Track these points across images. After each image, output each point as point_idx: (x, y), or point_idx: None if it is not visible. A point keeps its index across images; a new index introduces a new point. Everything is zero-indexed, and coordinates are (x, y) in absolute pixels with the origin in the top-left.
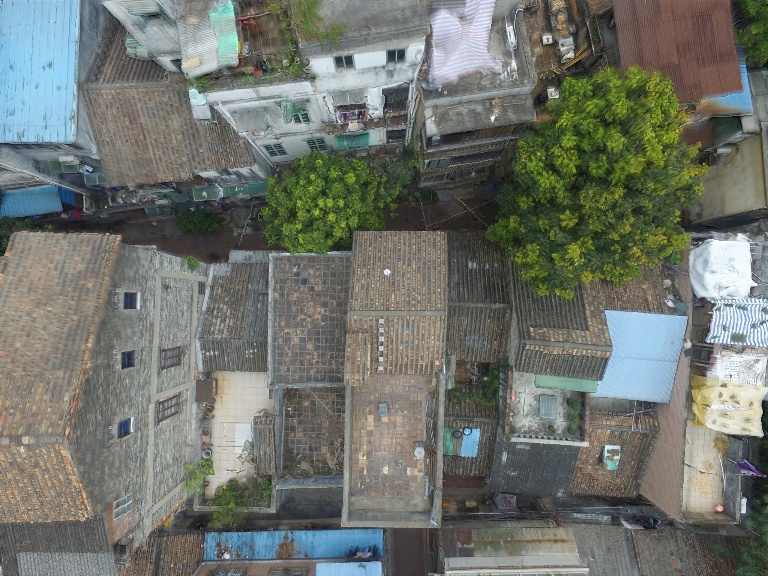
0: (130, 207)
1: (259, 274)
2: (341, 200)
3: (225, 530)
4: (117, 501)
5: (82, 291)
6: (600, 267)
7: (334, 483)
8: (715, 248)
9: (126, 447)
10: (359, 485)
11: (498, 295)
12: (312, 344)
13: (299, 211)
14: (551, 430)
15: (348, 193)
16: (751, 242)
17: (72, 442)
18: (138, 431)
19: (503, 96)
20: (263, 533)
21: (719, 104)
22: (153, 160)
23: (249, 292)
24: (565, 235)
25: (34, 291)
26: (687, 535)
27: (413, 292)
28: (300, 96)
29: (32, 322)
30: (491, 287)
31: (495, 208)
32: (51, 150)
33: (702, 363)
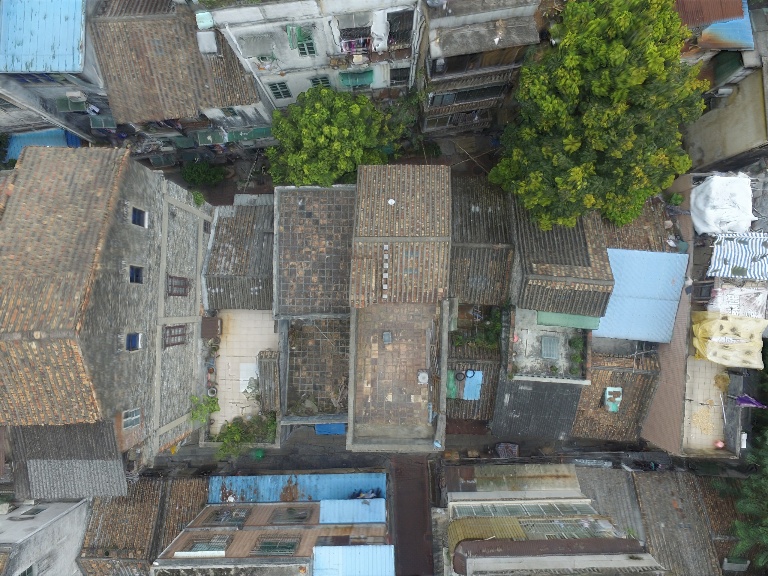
0: (135, 156)
1: (264, 215)
2: (346, 129)
3: (230, 474)
4: (126, 411)
5: (92, 199)
6: (602, 196)
7: (338, 419)
8: (716, 184)
9: (134, 361)
10: (363, 412)
11: (501, 236)
12: (317, 276)
13: (304, 139)
14: (553, 369)
15: (353, 125)
16: (752, 178)
17: (83, 338)
18: (146, 348)
19: (507, 18)
20: (267, 477)
21: (720, 38)
22: (159, 96)
23: (254, 232)
24: (568, 160)
25: (44, 200)
26: (688, 476)
27: (417, 220)
28: (306, 19)
29: (43, 228)
30: (494, 229)
31: (497, 157)
32: (58, 85)
33: (703, 300)
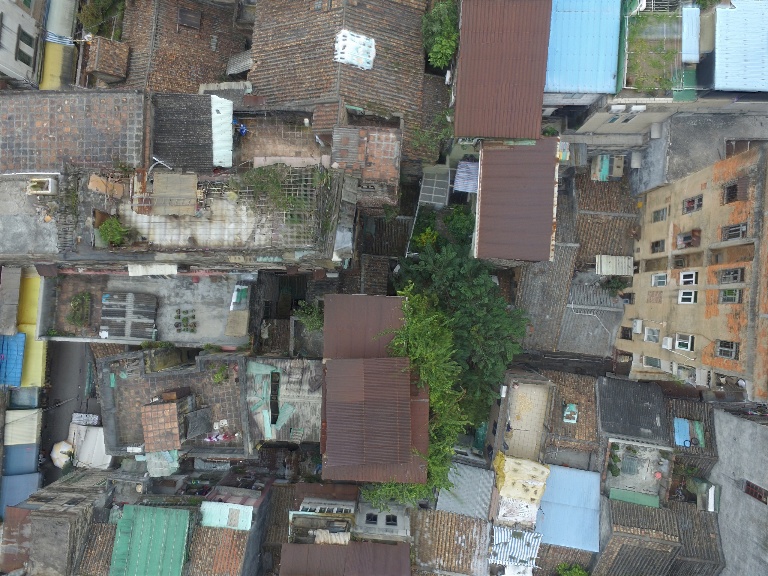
0: None
1: None
2: None
3: None
4: None
5: None
6: None
7: None
8: None
9: None
10: None
11: None
12: None
13: None
14: None
15: None
16: None
17: None
18: None
19: None
20: None
21: None
22: None
23: None
24: None
25: None
26: None
27: None
28: None
29: None
30: (673, 569)
31: None
32: None
33: None
